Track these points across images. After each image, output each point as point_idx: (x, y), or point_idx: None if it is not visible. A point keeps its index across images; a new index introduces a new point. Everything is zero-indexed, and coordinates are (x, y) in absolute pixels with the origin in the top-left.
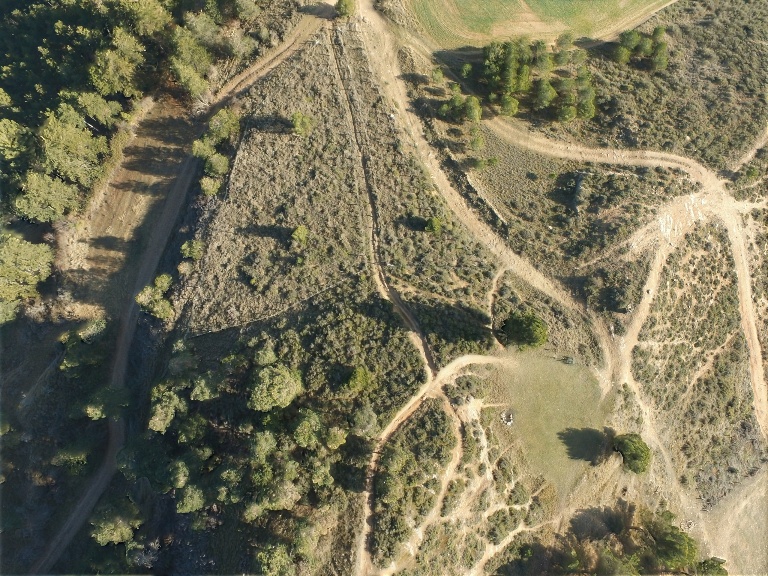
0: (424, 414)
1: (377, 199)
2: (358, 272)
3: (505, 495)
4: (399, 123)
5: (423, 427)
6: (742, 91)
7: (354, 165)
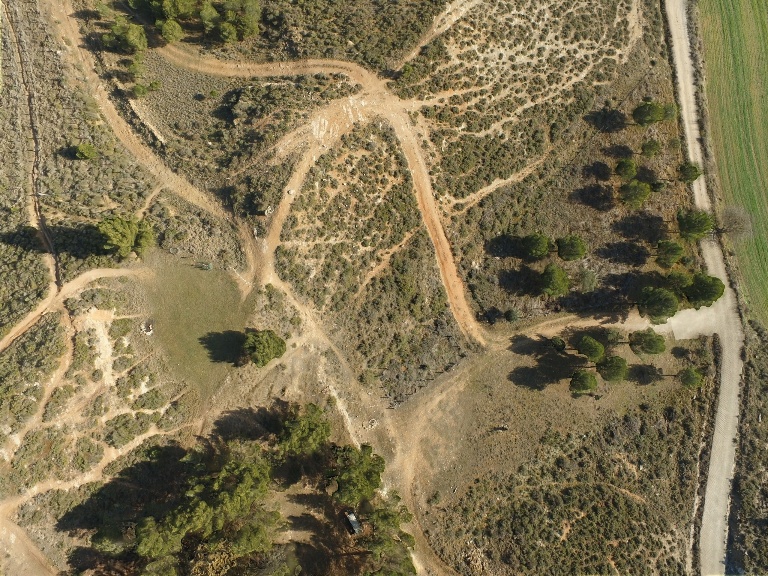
0: (40, 328)
1: (38, 133)
2: (13, 205)
3: (130, 400)
4: (67, 59)
5: (33, 339)
6: None
7: (18, 103)
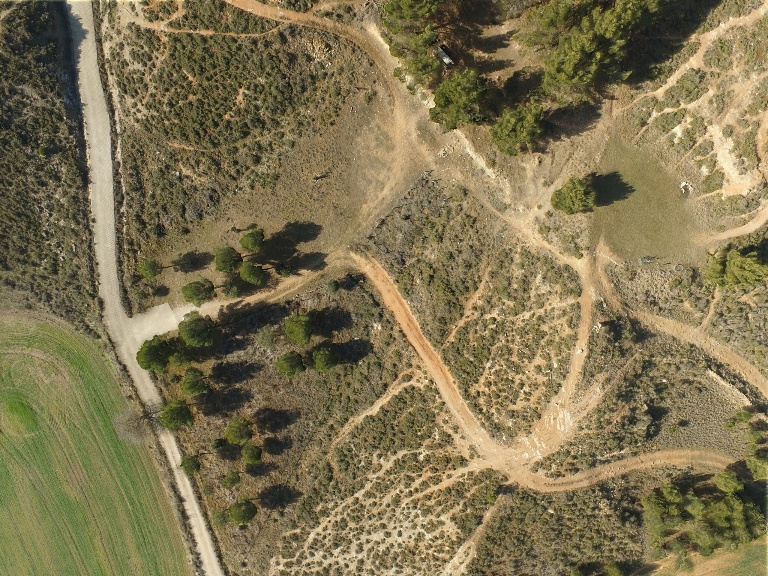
0: None
1: None
2: None
3: (689, 117)
4: None
5: None
6: (502, 575)
7: None
